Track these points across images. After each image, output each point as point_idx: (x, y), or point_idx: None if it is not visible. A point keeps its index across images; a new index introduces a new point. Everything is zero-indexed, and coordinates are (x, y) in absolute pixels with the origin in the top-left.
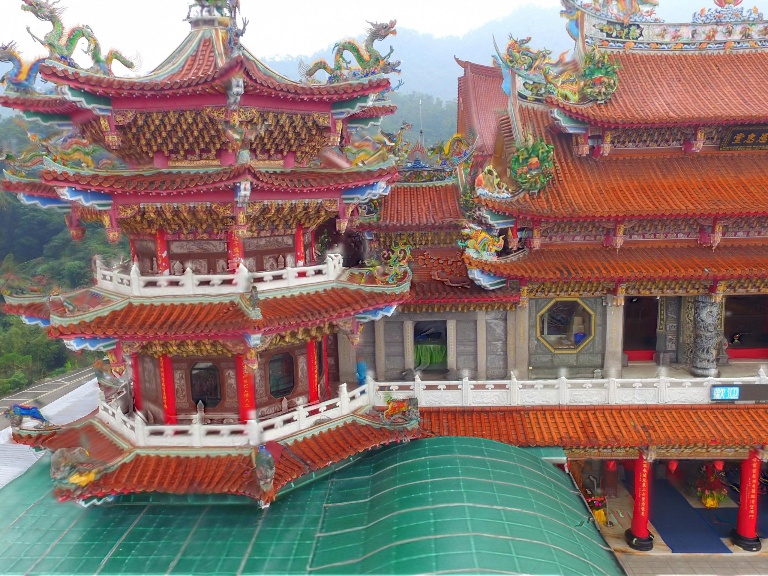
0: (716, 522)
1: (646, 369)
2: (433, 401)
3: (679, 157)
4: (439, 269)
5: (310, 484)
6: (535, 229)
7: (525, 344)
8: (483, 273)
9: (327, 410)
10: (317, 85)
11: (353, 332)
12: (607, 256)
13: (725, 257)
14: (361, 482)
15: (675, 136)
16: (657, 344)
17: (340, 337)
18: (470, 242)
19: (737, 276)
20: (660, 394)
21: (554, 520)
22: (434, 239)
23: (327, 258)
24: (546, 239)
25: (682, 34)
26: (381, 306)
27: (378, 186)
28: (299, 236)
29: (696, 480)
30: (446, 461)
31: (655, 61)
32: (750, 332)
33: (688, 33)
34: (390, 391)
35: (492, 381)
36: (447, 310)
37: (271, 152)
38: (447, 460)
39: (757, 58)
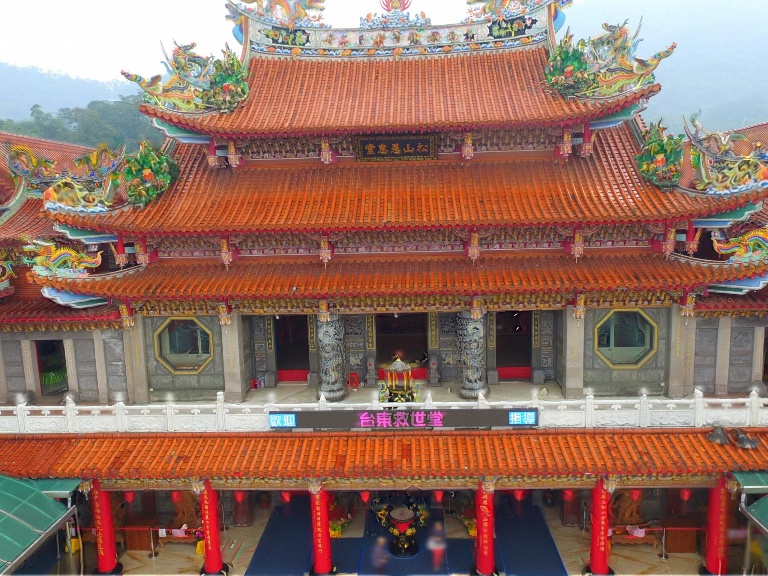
0: None
1: (288, 390)
2: None
3: (318, 168)
4: None
5: None
6: (137, 244)
7: (141, 365)
8: (59, 291)
9: None
10: None
11: None
12: (217, 273)
13: (331, 274)
14: None
15: (308, 146)
16: (310, 364)
17: None
18: (38, 259)
19: (326, 295)
20: (219, 421)
21: None
22: None
23: None
24: (165, 254)
25: (349, 40)
26: None
27: None
28: None
29: None
30: None
31: (319, 68)
32: None
33: (355, 39)
34: None
35: (48, 407)
36: (55, 329)
37: None
38: None
39: (423, 65)
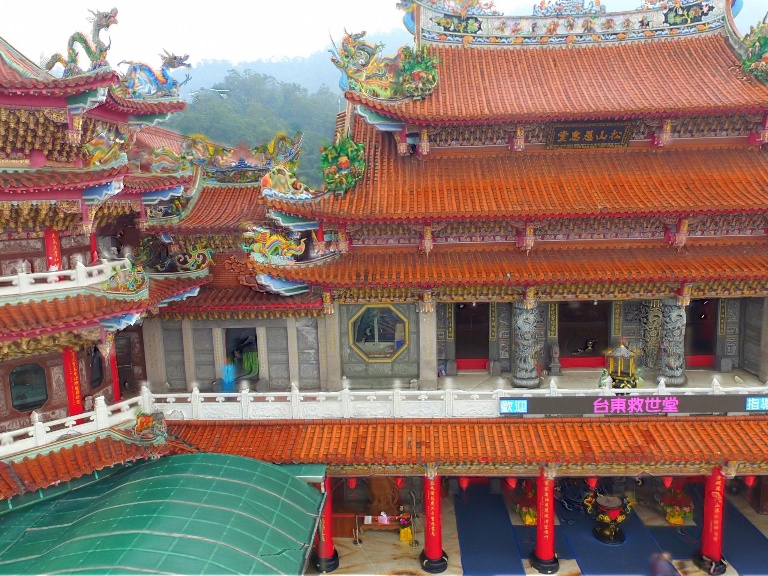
0: (526, 541)
1: (473, 379)
2: (212, 414)
3: (505, 156)
4: (247, 274)
5: (33, 505)
6: (339, 232)
7: (336, 353)
8: (273, 278)
9: (78, 425)
10: (55, 79)
11: (101, 342)
12: (417, 260)
13: (537, 261)
14: (84, 503)
15: (498, 134)
16: (490, 352)
17: (146, 345)
18: (255, 246)
19: (541, 281)
20: (447, 407)
21: (236, 549)
22: (236, 242)
23: (77, 263)
24: (359, 242)
25: (522, 27)
26: (120, 314)
27: (113, 186)
28: (51, 240)
29: (517, 496)
30: (169, 481)
31: (493, 56)
32: (595, 339)
33: (528, 26)
34: (167, 403)
35: (272, 393)
36: (252, 317)
37: (7, 150)
38: (171, 480)
39: (598, 52)
